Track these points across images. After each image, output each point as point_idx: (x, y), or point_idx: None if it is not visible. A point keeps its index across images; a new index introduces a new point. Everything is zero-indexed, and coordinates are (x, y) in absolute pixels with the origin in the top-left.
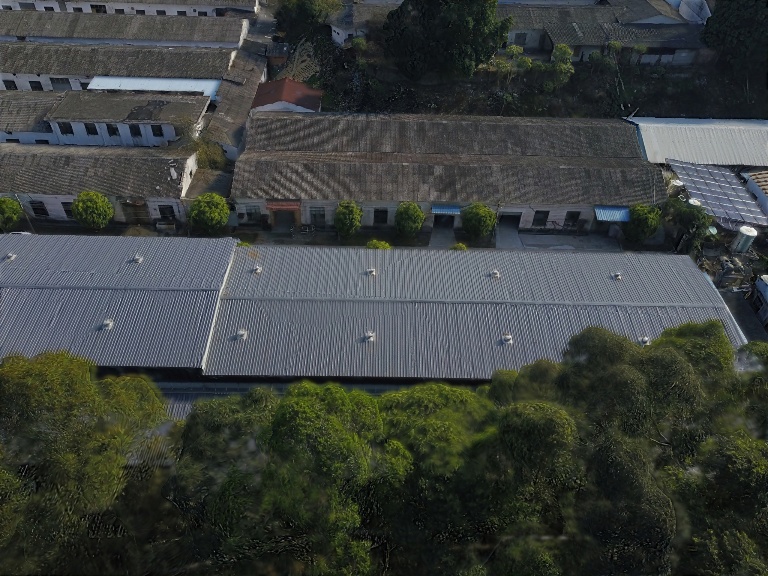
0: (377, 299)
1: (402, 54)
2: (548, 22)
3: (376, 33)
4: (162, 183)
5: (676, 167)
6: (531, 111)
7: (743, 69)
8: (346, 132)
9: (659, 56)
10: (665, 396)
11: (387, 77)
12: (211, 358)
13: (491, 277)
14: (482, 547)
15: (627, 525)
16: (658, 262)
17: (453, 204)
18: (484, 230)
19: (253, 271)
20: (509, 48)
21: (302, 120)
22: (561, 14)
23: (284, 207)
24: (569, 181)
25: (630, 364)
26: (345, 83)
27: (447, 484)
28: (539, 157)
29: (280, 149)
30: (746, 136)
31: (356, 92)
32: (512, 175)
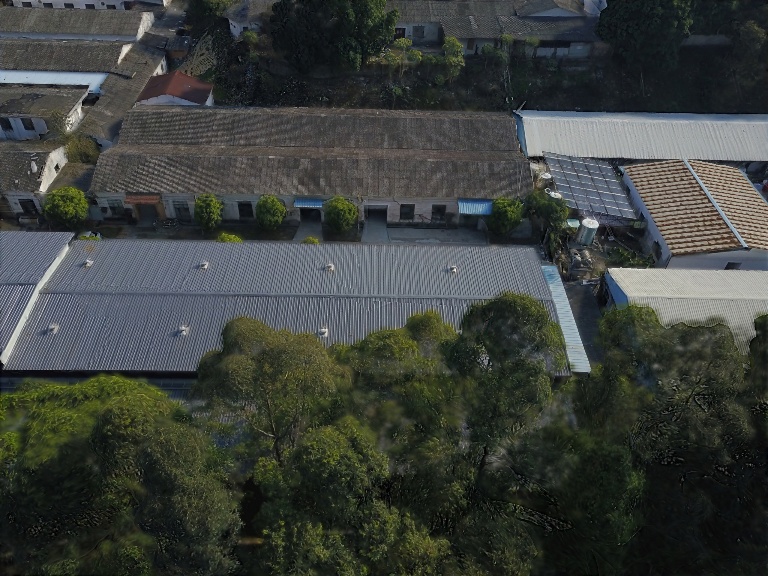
0: (200, 293)
1: (288, 47)
2: (446, 15)
3: (270, 26)
4: (21, 177)
5: (551, 160)
6: (423, 104)
7: (636, 62)
8: (222, 125)
9: (554, 49)
10: (284, 387)
11: (280, 70)
12: (15, 353)
13: (324, 270)
14: (87, 541)
15: (157, 517)
16: (500, 255)
17: (315, 197)
18: (344, 224)
19: (83, 265)
20: (397, 41)
21: (179, 113)
22: (460, 7)
23: (142, 201)
24: (435, 174)
25: (248, 354)
26: (239, 76)
27: (32, 477)
28: (414, 150)
29: (153, 143)
30: (629, 129)
31: (248, 85)
32: (378, 168)
